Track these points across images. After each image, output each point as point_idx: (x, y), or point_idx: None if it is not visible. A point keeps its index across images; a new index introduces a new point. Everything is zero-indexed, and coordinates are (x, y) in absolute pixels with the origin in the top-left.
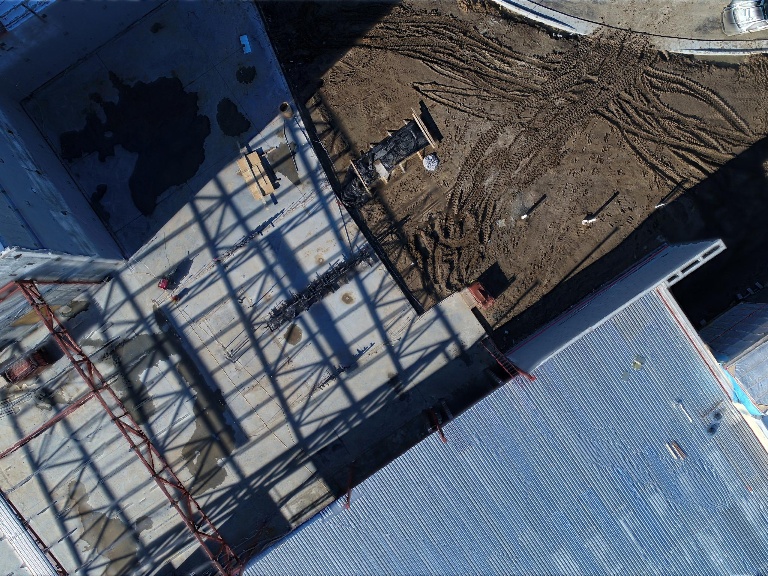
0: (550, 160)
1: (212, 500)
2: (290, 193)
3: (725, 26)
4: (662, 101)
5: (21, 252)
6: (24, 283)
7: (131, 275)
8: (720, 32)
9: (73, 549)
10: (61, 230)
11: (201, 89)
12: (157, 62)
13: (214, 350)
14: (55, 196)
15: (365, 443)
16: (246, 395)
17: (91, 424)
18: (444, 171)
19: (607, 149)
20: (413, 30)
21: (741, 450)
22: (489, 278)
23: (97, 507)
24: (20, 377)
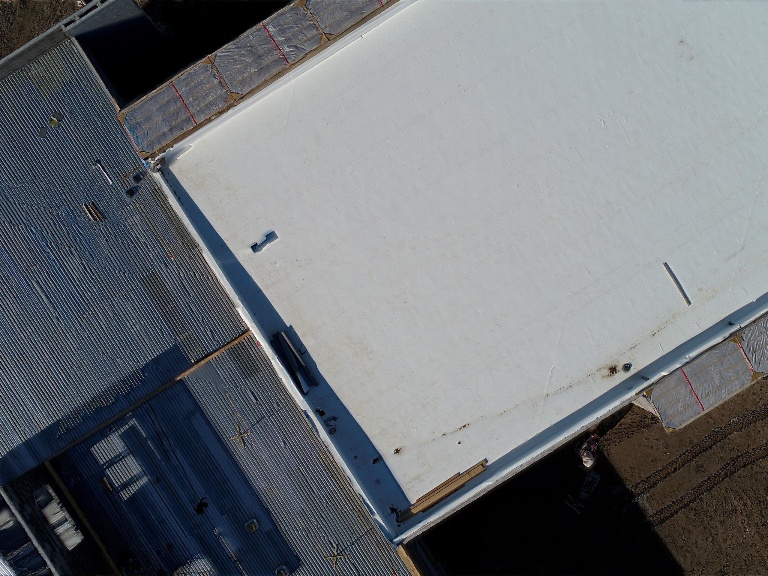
0: None
1: None
2: None
3: None
4: None
5: None
6: None
7: None
8: None
9: None
10: None
11: None
12: None
13: None
14: None
15: None
16: None
17: None
18: None
19: None
20: None
21: (163, 215)
22: None
23: None
24: None
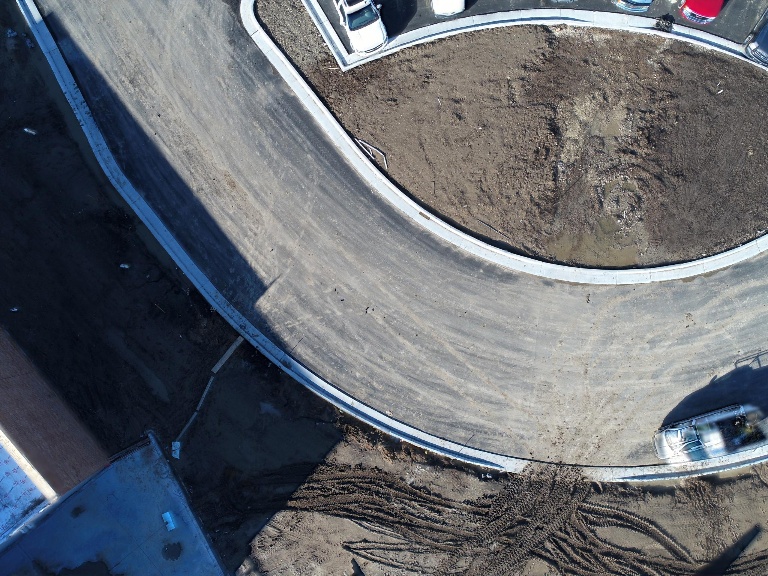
0: None
1: None
2: None
3: (658, 450)
4: (599, 536)
5: None
6: None
7: None
8: (653, 456)
9: None
10: None
11: (127, 570)
12: (80, 547)
13: None
14: None
15: None
16: None
17: None
18: None
19: None
20: (338, 487)
21: None
22: None
23: None
24: None
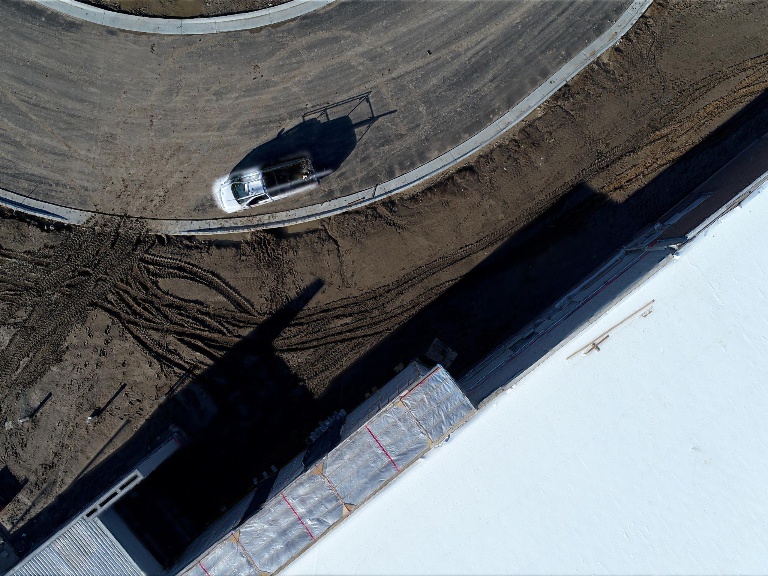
0: (52, 357)
1: None
2: None
3: (224, 203)
4: (161, 288)
5: None
6: None
7: None
8: (220, 210)
9: None
10: None
11: None
12: None
13: None
14: None
15: None
16: None
17: None
18: None
19: (109, 341)
20: None
21: None
22: (1, 482)
23: None
24: None
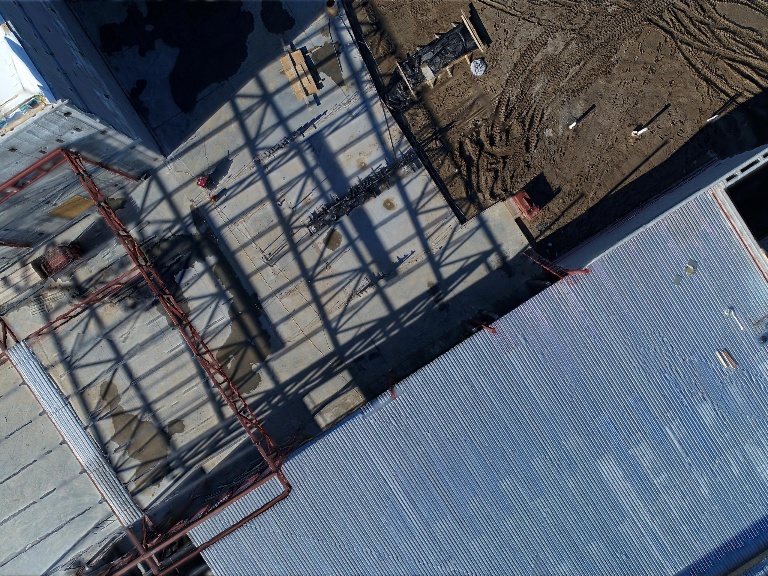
0: (601, 69)
1: None
2: (333, 94)
3: None
4: (718, 11)
5: (71, 110)
6: (70, 153)
7: (169, 174)
8: None
9: (103, 450)
10: (105, 108)
11: None
12: None
13: (251, 253)
14: (97, 80)
15: (402, 352)
16: (283, 300)
17: (125, 324)
18: (492, 77)
19: (660, 59)
20: None
21: None
22: (534, 188)
23: (129, 409)
24: (56, 269)
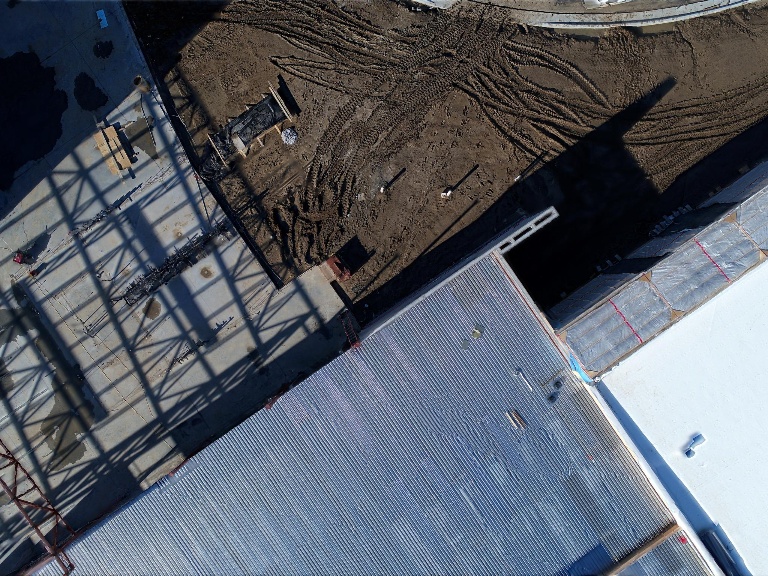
0: (409, 133)
1: (71, 475)
2: (148, 167)
3: None
4: (521, 74)
5: None
6: None
7: None
8: (580, 5)
9: None
10: None
11: (58, 64)
12: (14, 37)
13: (73, 325)
14: None
15: (225, 417)
16: (105, 370)
17: None
18: (303, 145)
19: (466, 122)
20: (271, 4)
21: (582, 418)
22: (349, 252)
23: None
24: None
